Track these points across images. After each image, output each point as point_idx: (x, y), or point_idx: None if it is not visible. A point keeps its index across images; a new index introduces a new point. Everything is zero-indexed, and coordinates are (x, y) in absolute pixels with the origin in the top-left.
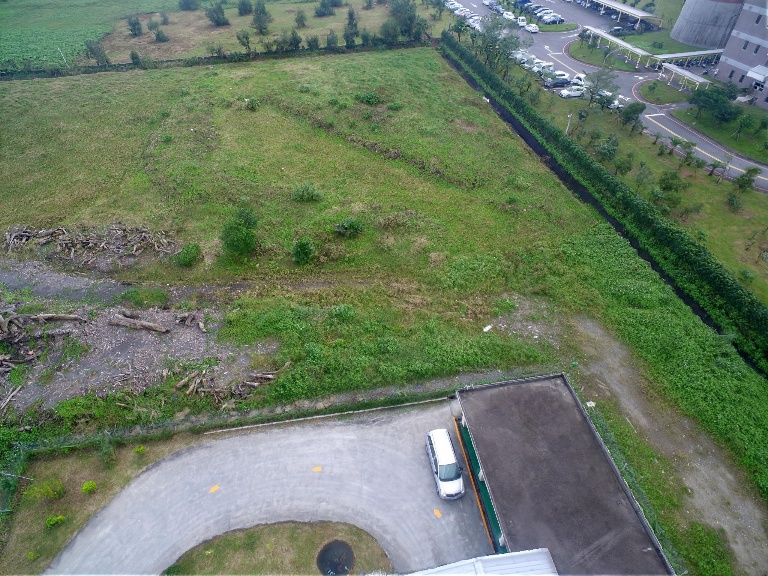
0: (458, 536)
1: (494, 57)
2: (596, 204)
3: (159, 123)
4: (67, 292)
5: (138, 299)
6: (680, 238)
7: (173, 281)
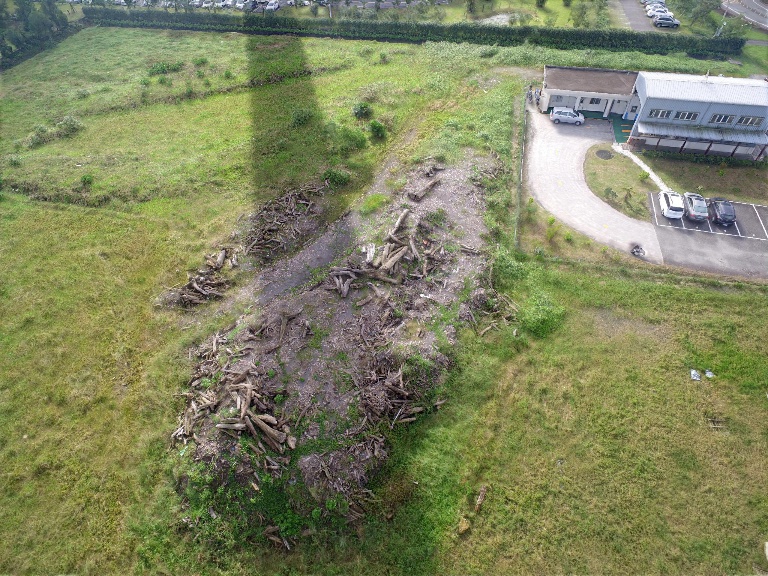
0: (599, 126)
1: (188, 5)
2: (402, 42)
3: (8, 193)
4: (336, 245)
5: (376, 205)
6: (464, 24)
7: (363, 190)
